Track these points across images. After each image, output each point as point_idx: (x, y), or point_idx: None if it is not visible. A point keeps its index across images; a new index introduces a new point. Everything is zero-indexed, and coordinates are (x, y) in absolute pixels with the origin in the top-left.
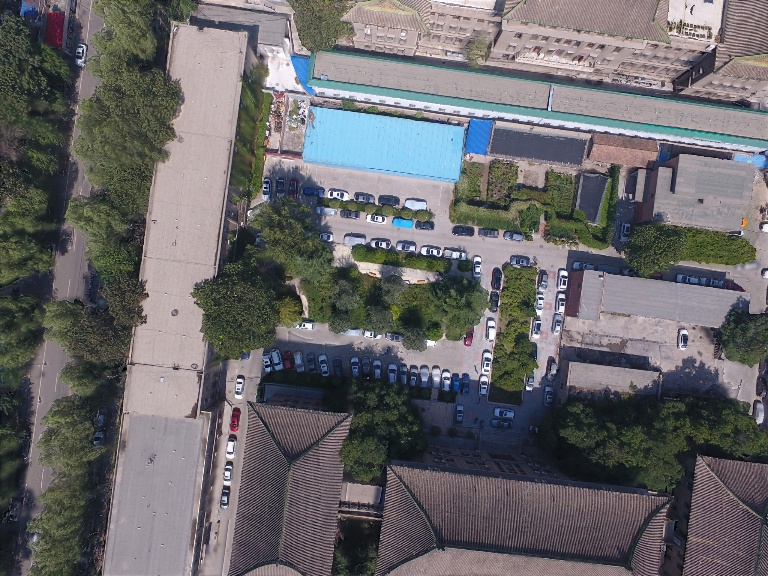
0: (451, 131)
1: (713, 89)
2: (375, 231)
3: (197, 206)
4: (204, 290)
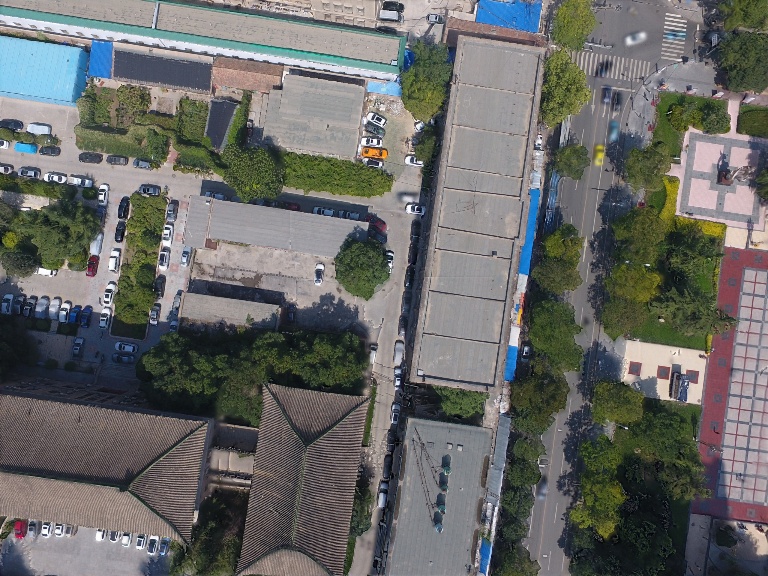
0: (67, 52)
1: (335, 11)
2: None
3: None
4: None
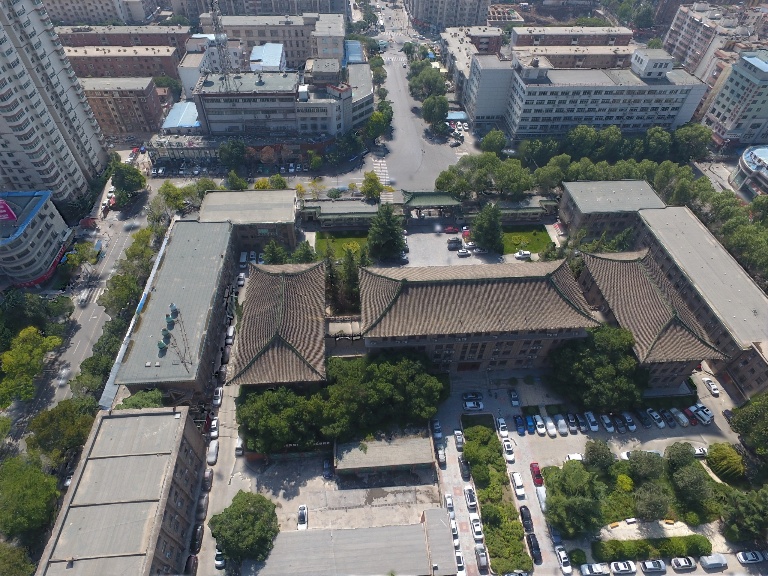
0: None
1: None
2: None
3: None
4: None
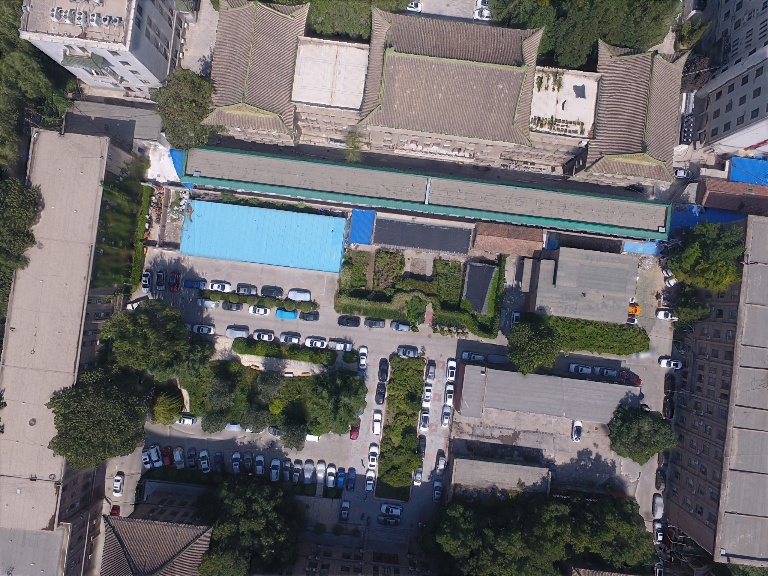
0: (331, 222)
1: (598, 178)
2: (258, 322)
3: (56, 313)
4: (60, 400)
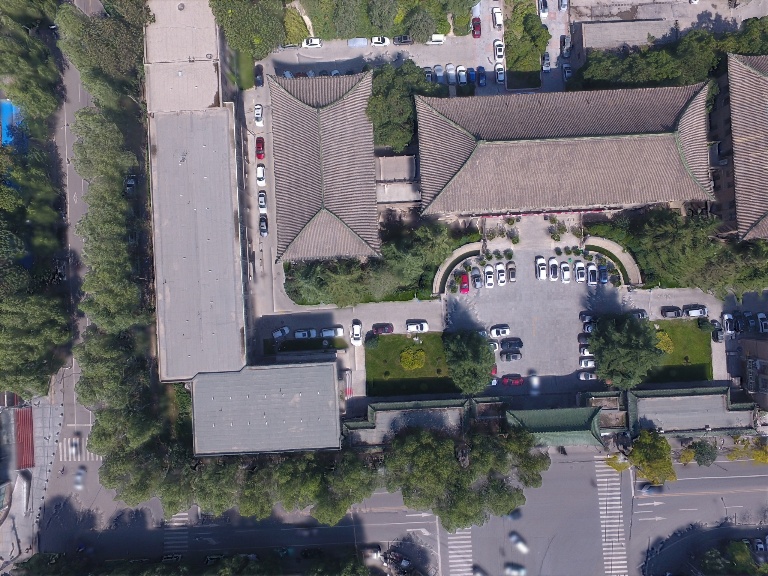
0: None
1: None
2: None
3: None
4: None
